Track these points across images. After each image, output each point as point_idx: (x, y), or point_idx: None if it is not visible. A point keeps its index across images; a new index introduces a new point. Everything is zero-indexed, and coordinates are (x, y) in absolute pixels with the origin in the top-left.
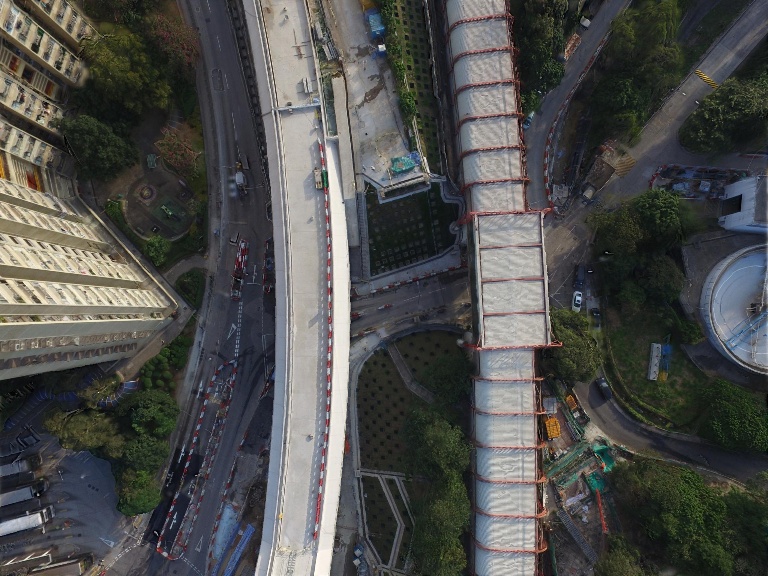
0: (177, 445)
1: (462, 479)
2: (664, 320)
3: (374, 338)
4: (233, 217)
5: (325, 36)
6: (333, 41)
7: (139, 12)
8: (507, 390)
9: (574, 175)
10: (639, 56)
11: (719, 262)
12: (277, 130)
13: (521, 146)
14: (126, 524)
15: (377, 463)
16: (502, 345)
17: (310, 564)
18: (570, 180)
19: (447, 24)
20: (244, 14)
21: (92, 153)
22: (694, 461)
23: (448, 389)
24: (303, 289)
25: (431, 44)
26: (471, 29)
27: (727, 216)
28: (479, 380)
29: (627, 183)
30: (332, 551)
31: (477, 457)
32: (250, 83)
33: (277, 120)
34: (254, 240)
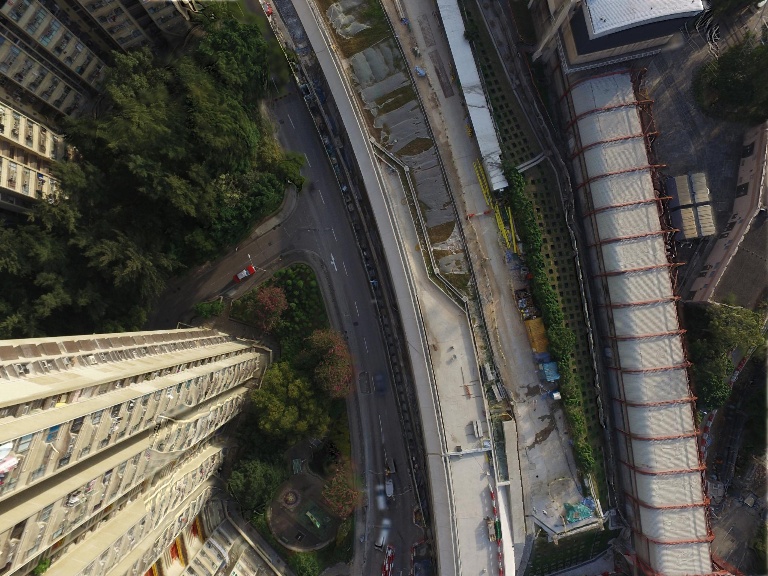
0: None
1: None
2: None
3: None
4: (378, 521)
5: (493, 375)
6: (502, 380)
7: (288, 319)
8: None
9: (729, 473)
10: None
11: None
12: (447, 477)
13: (706, 504)
14: None
15: None
16: None
17: None
18: (725, 477)
19: (618, 361)
20: (402, 336)
21: (257, 503)
22: None
23: None
24: None
25: (595, 369)
26: (649, 378)
27: None
28: None
29: None
30: None
31: None
32: (400, 390)
33: (447, 466)
34: (400, 544)
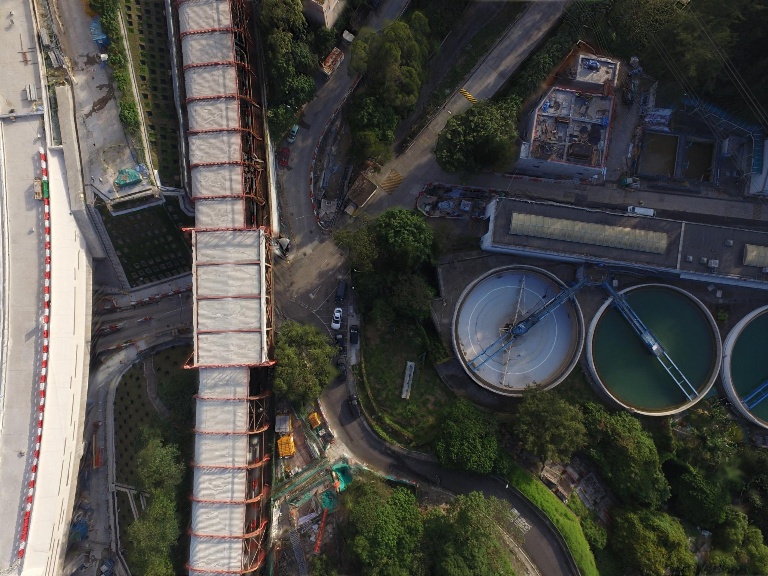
0: None
1: (172, 498)
2: (414, 339)
3: (133, 350)
4: None
5: (53, 43)
6: (61, 48)
7: None
8: (221, 409)
9: (343, 190)
10: (379, 74)
11: (472, 282)
12: None
13: (242, 162)
14: None
15: (127, 478)
16: (215, 363)
17: None
18: (339, 195)
19: None
20: None
21: None
22: (430, 481)
23: (177, 406)
24: (21, 302)
25: (174, 54)
26: (195, 41)
27: (484, 236)
28: (196, 398)
29: (395, 200)
30: (57, 568)
31: None
32: None
33: None
34: None
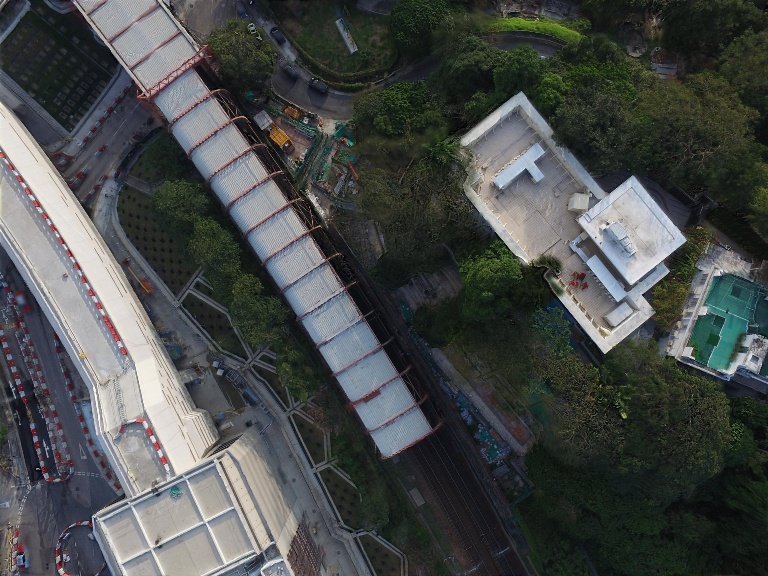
0: (3, 385)
1: (210, 218)
2: None
3: (110, 183)
4: None
5: None
6: None
7: None
8: (196, 119)
9: None
10: None
11: None
12: None
13: None
14: (7, 480)
15: (180, 281)
16: None
17: (134, 376)
18: None
19: None
20: None
21: None
22: None
23: (166, 163)
24: None
25: None
26: None
27: None
28: (171, 129)
29: None
30: (169, 365)
31: (217, 196)
32: None
33: None
34: None
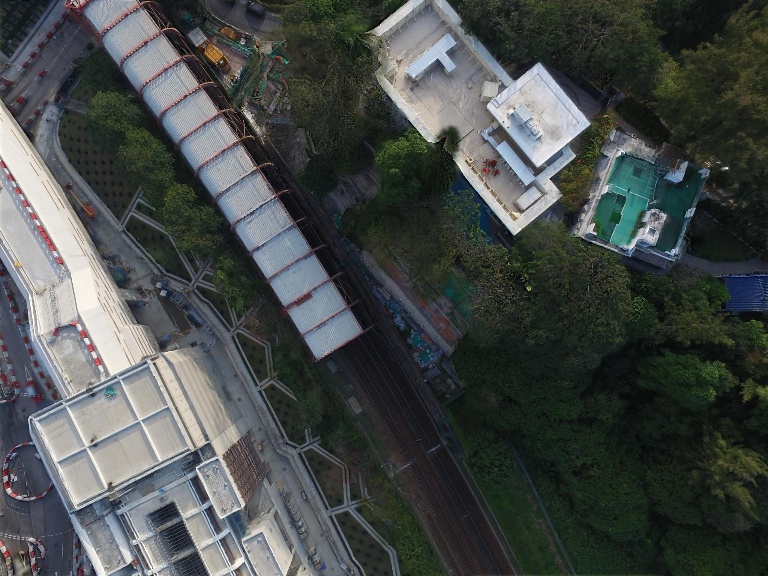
0: None
1: None
2: None
3: (51, 108)
4: None
5: None
6: None
7: None
8: (127, 31)
9: None
10: None
11: None
12: None
13: None
14: None
15: (122, 203)
16: None
17: (70, 285)
18: None
19: None
20: None
21: None
22: None
23: (101, 79)
24: None
25: None
26: None
27: None
28: (102, 41)
29: None
30: (108, 280)
31: (151, 108)
32: None
33: None
34: None
